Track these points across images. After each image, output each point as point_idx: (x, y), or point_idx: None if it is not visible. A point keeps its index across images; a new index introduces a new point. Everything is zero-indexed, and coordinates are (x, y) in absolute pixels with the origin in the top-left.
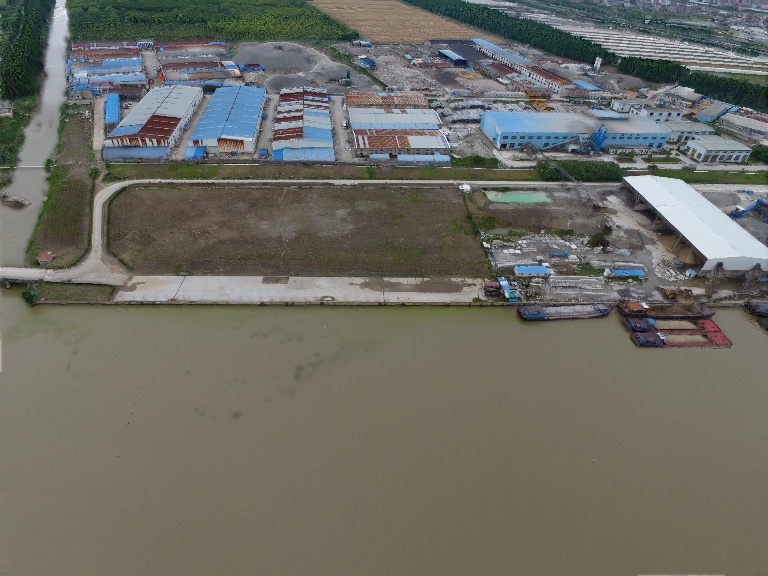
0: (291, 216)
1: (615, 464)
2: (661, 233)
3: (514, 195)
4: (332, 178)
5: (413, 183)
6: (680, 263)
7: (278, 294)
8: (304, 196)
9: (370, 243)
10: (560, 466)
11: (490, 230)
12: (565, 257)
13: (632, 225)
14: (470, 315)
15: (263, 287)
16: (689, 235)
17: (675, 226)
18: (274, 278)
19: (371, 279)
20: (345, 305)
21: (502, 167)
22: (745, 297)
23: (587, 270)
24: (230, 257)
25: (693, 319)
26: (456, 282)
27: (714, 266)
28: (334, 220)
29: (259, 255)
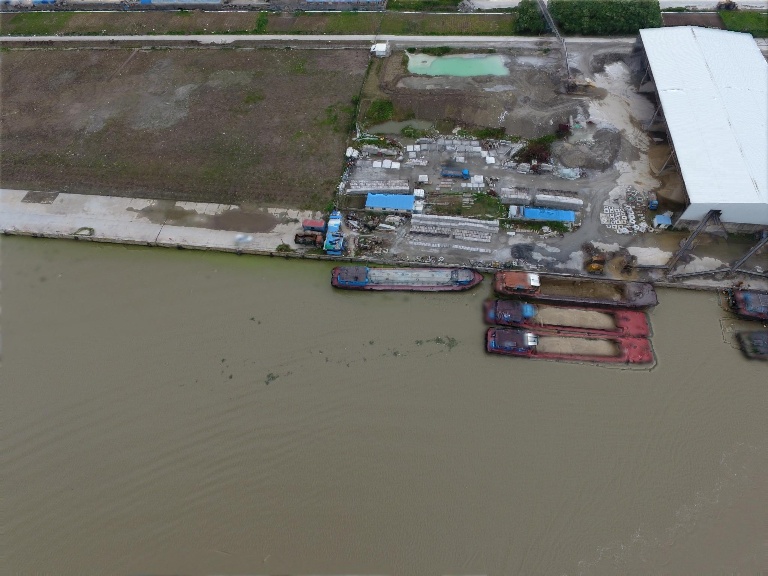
0: (116, 95)
1: (295, 573)
2: (661, 138)
3: (454, 61)
4: (203, 32)
5: (311, 40)
6: (653, 201)
7: (30, 220)
8: (151, 62)
9: (190, 143)
10: (195, 568)
11: (376, 125)
12: (464, 178)
13: (617, 121)
14: (259, 273)
15: (19, 208)
16: (686, 152)
17: (671, 132)
18: (40, 194)
19: (159, 203)
20: (105, 242)
21: (463, 10)
22: (739, 275)
23: (485, 205)
24: (6, 159)
25: (615, 310)
26: (272, 215)
27: (703, 215)
28: (166, 103)
29: (41, 157)
